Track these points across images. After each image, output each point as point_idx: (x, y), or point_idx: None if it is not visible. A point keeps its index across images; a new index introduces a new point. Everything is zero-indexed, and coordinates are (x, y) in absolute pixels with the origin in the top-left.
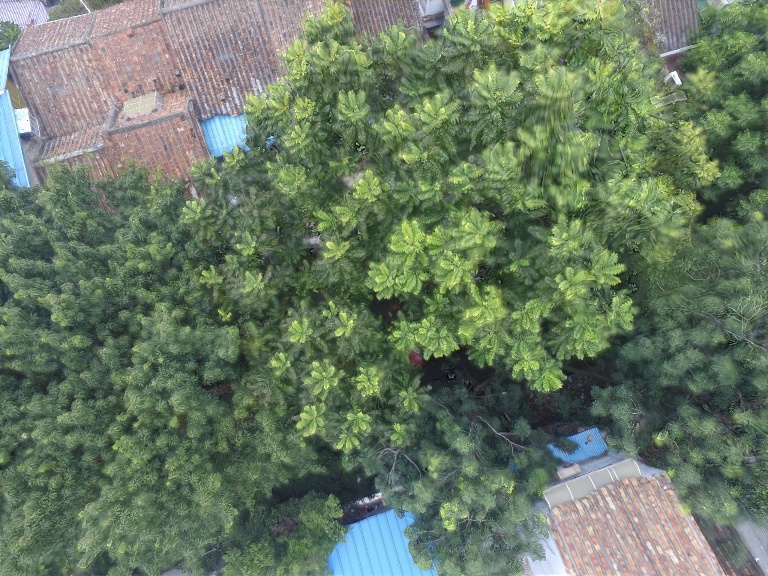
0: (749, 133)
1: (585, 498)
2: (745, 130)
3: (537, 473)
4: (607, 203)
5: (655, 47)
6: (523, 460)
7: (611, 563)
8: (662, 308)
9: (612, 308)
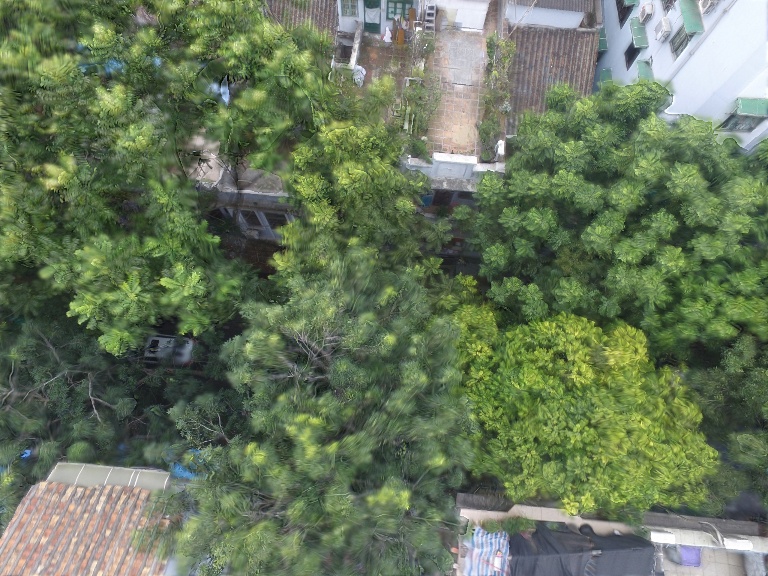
0: (517, 211)
1: (84, 487)
2: (514, 207)
3: (78, 446)
4: (80, 106)
5: (500, 114)
6: (85, 430)
7: (38, 563)
8: (270, 319)
9: (191, 284)
